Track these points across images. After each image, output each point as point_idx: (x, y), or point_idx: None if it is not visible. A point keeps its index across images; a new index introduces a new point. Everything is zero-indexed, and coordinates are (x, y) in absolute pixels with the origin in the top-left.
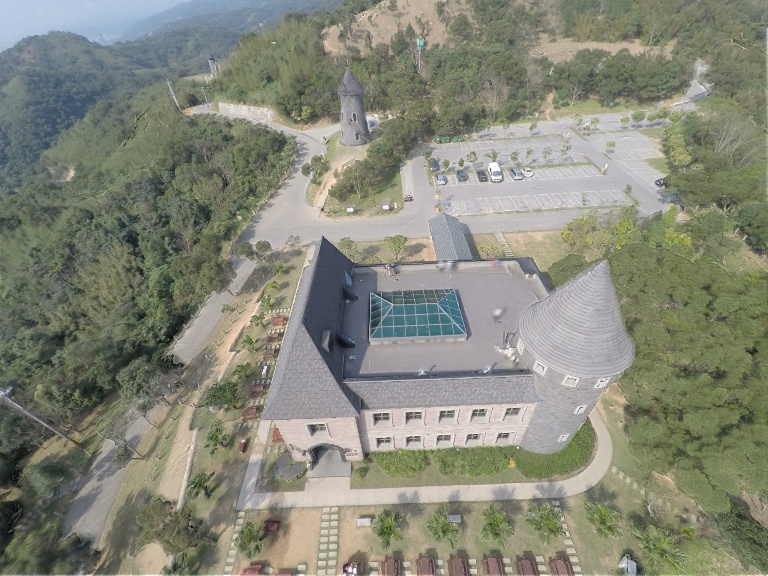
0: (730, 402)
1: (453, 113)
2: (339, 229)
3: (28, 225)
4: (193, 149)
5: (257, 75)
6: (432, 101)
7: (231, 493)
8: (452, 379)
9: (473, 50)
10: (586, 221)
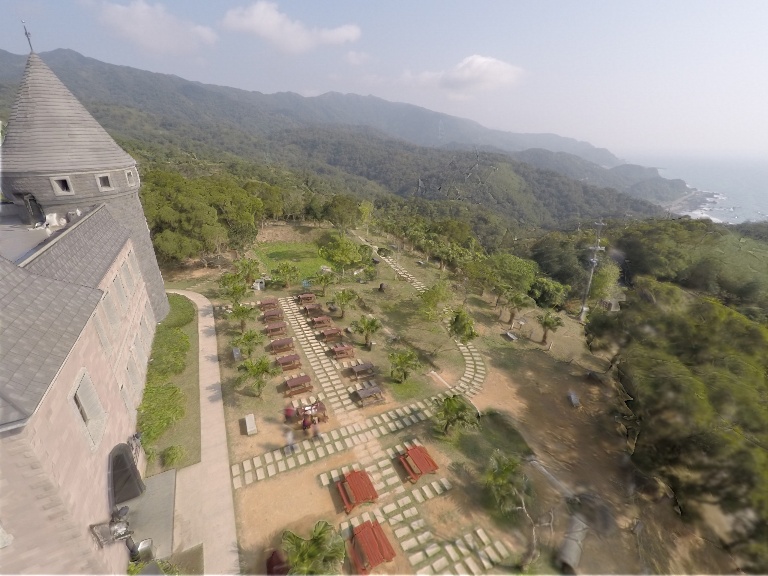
0: None
1: None
2: None
3: None
4: None
5: None
6: None
7: None
8: (80, 224)
9: None
10: None
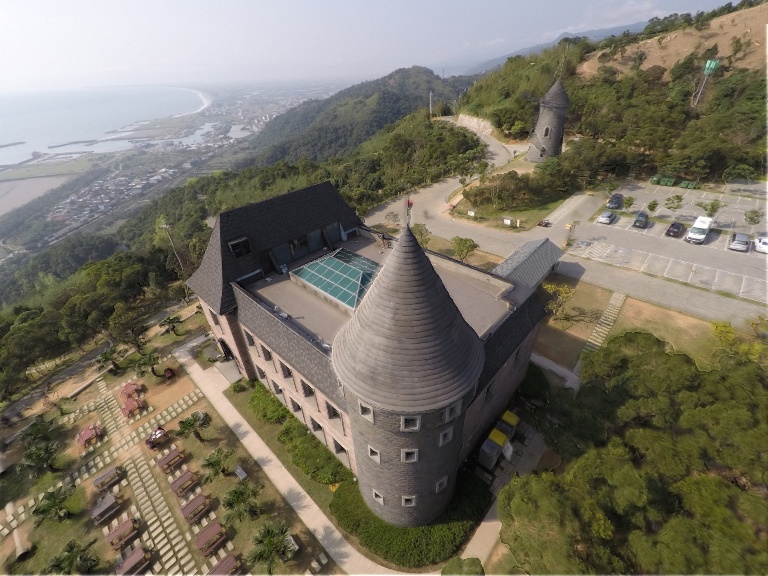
0: None
1: (694, 149)
2: (447, 226)
3: (300, 173)
4: (411, 144)
5: (498, 91)
6: (673, 131)
7: (181, 342)
8: (286, 326)
9: None
10: None
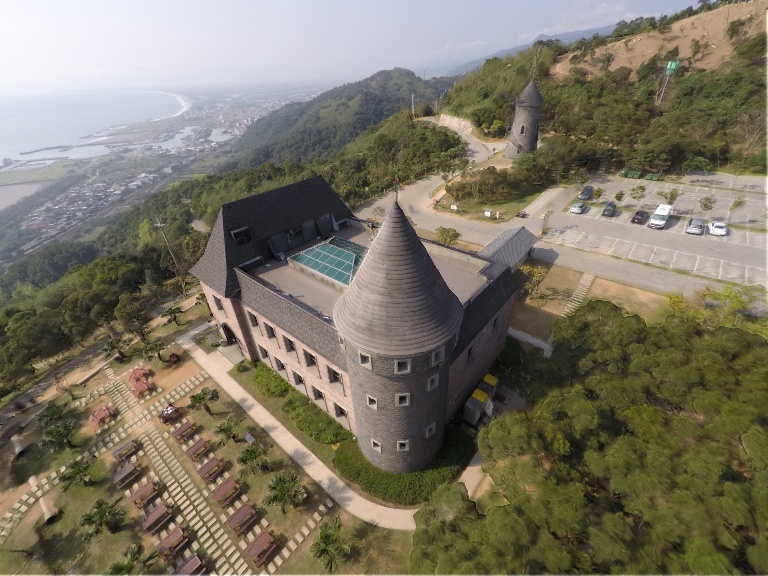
0: (571, 538)
1: (656, 143)
2: (431, 220)
3: (286, 175)
4: (395, 144)
5: (477, 91)
6: (638, 128)
7: (183, 331)
8: (289, 302)
9: (753, 76)
10: (731, 298)
